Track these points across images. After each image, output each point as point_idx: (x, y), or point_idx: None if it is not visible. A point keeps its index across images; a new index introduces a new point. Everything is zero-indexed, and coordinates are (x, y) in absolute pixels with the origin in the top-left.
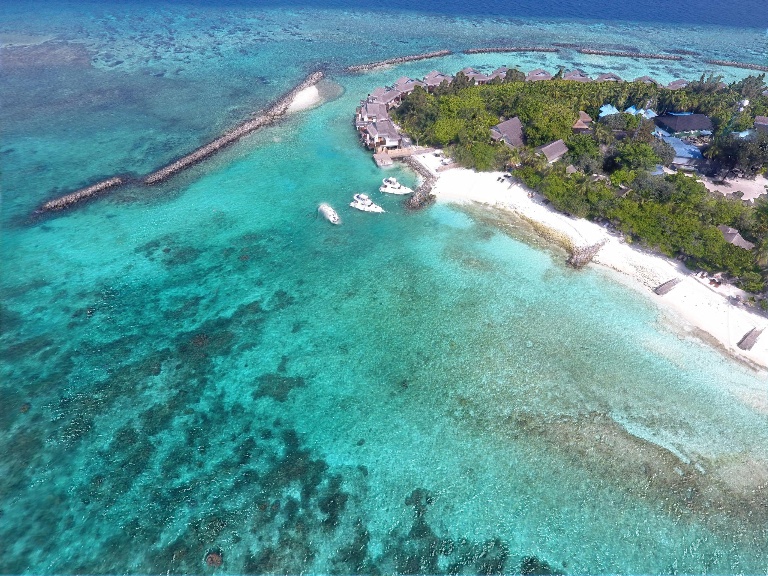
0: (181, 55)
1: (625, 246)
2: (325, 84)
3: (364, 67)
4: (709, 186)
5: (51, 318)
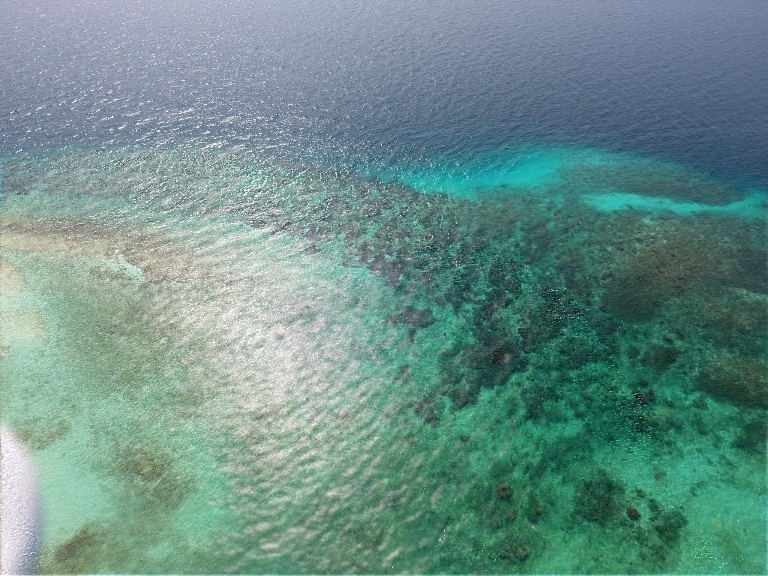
0: None
1: None
2: None
3: None
4: None
5: (674, 393)
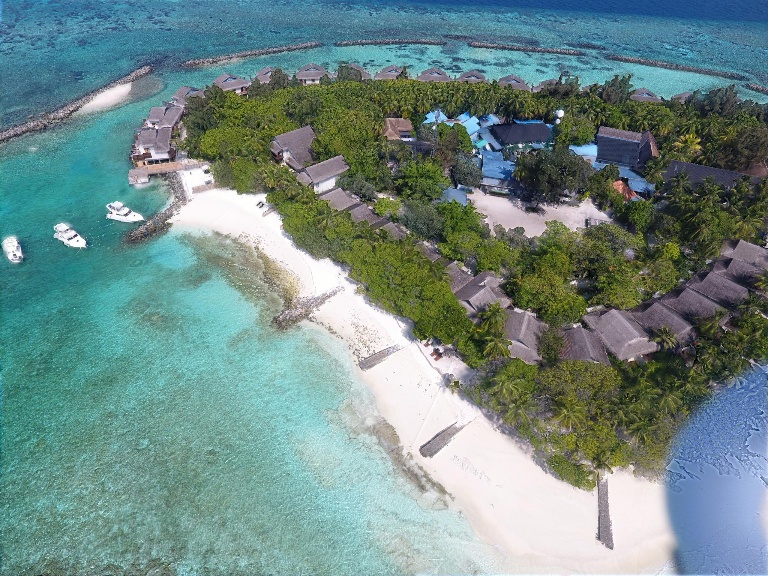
0: (7, 45)
1: (359, 297)
2: (146, 81)
3: (206, 61)
4: (518, 214)
5: None
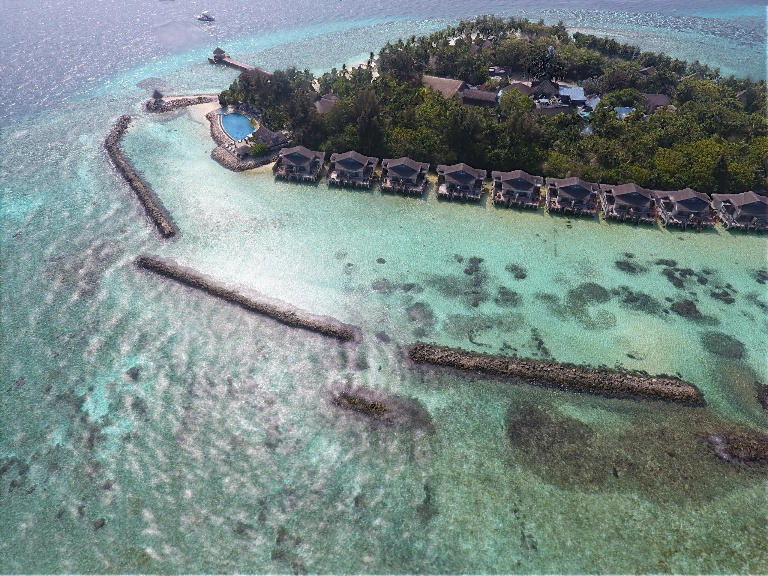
0: None
1: None
2: None
3: None
4: None
5: None
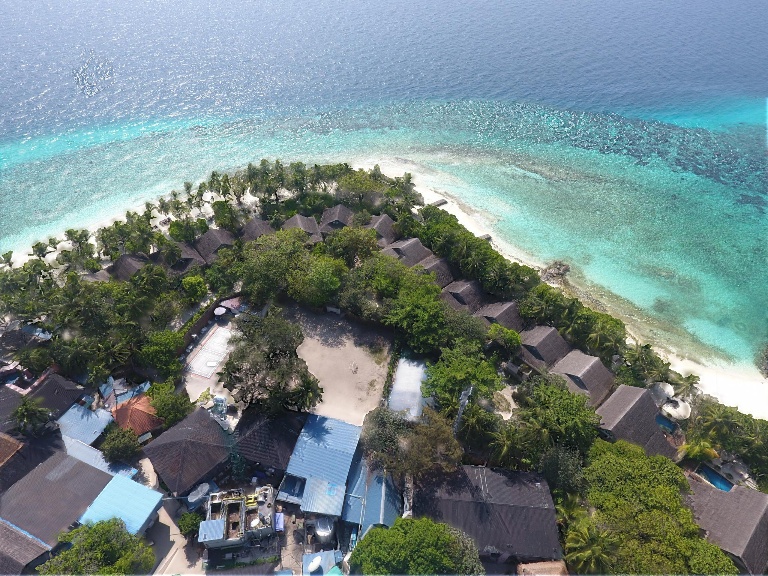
0: None
1: None
2: None
3: None
4: None
5: None
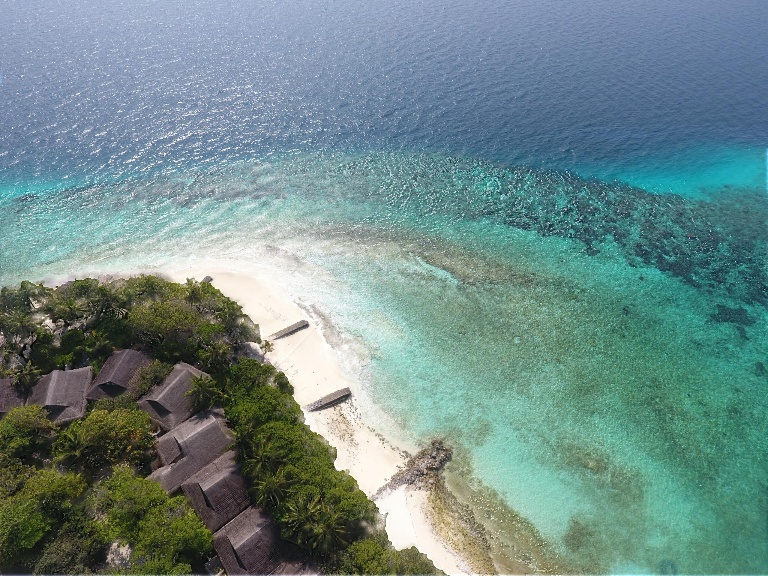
0: None
1: None
2: None
3: None
4: None
5: None
